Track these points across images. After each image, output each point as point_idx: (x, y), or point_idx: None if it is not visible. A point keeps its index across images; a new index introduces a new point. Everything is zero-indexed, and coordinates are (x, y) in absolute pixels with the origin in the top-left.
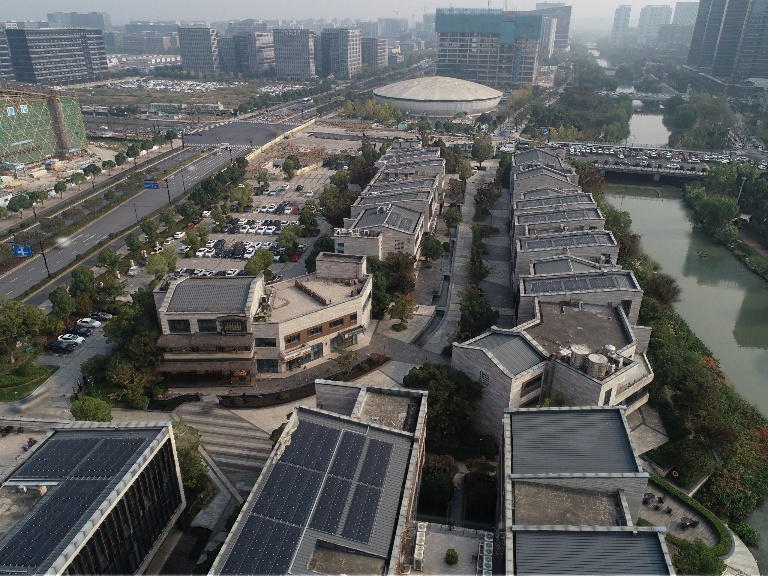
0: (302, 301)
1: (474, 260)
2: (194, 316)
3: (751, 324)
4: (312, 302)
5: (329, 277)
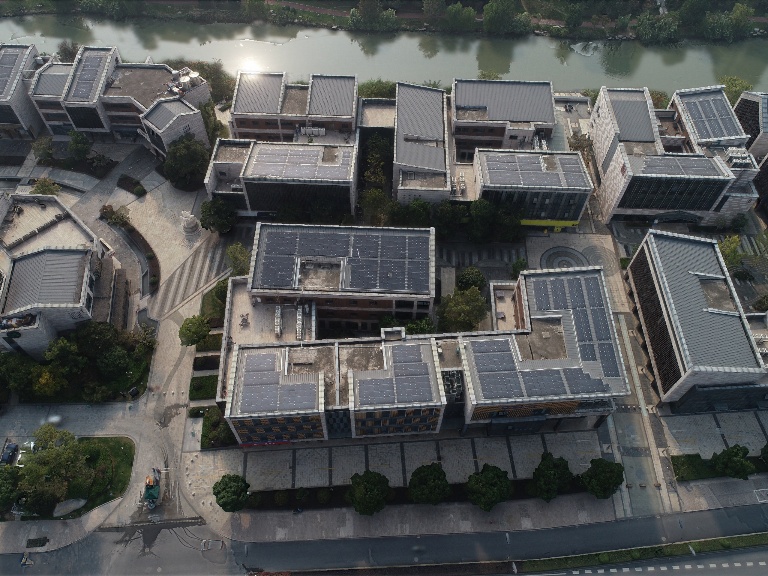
0: (46, 238)
1: None
2: None
3: (73, 41)
4: (50, 231)
5: (0, 226)
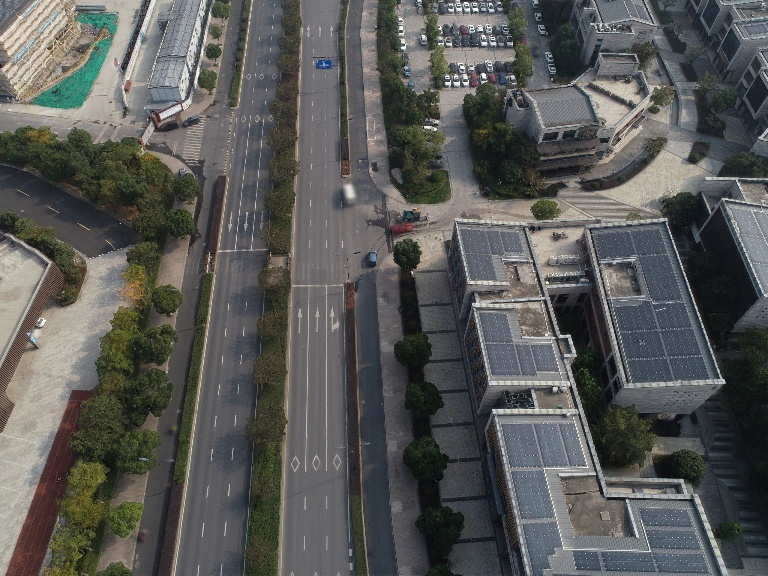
0: (607, 102)
1: (670, 32)
2: (563, 129)
3: None
4: (615, 102)
5: (609, 75)
